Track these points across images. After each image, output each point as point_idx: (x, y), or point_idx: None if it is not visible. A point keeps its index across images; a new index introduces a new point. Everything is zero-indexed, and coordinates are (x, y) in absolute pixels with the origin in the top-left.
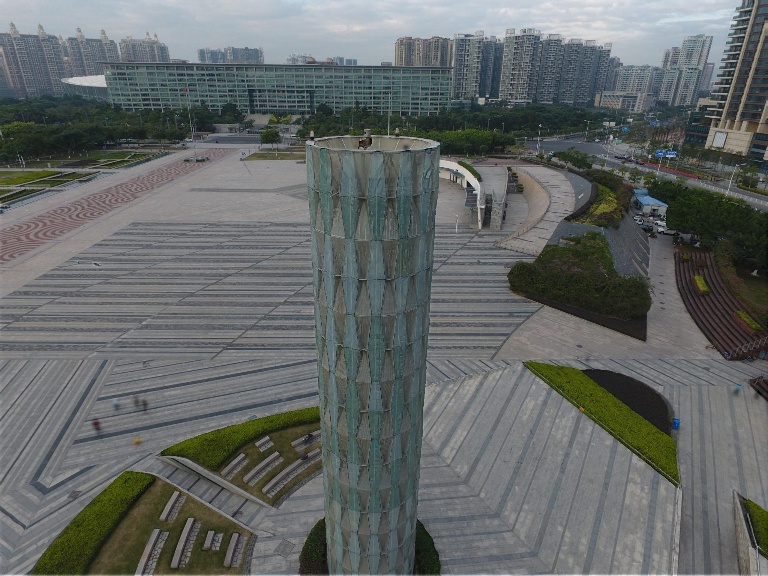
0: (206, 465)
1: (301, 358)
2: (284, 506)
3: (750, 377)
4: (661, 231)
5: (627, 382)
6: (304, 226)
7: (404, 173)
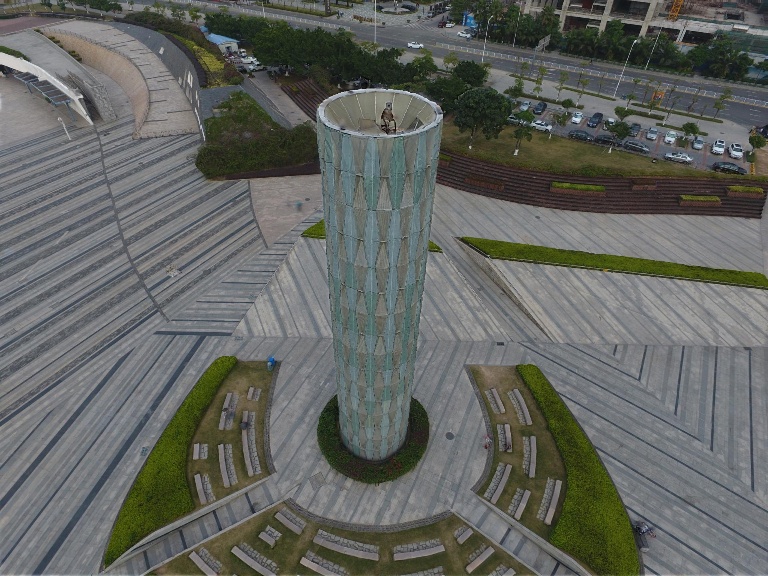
0: (181, 514)
1: (103, 369)
2: (278, 465)
3: None
4: (253, 69)
5: None
6: None
7: None
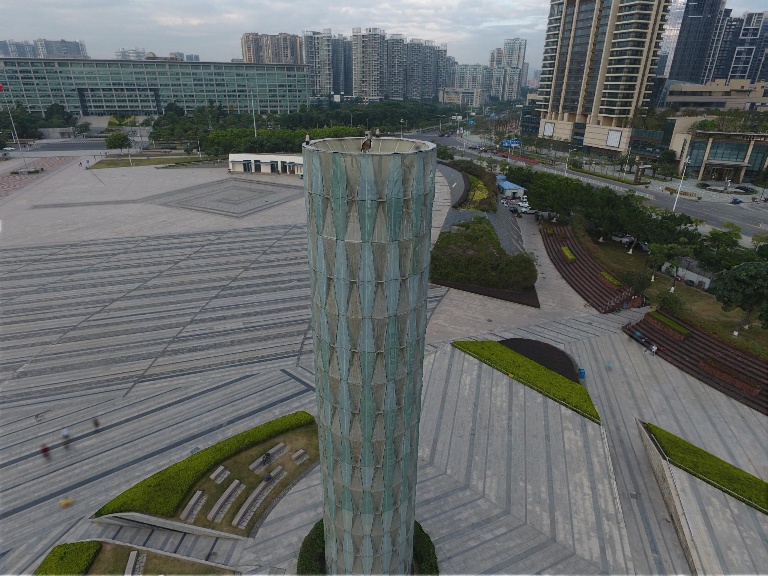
0: (160, 513)
1: (230, 377)
2: (261, 533)
3: (621, 325)
4: (524, 211)
5: (536, 345)
6: (188, 237)
7: (416, 173)
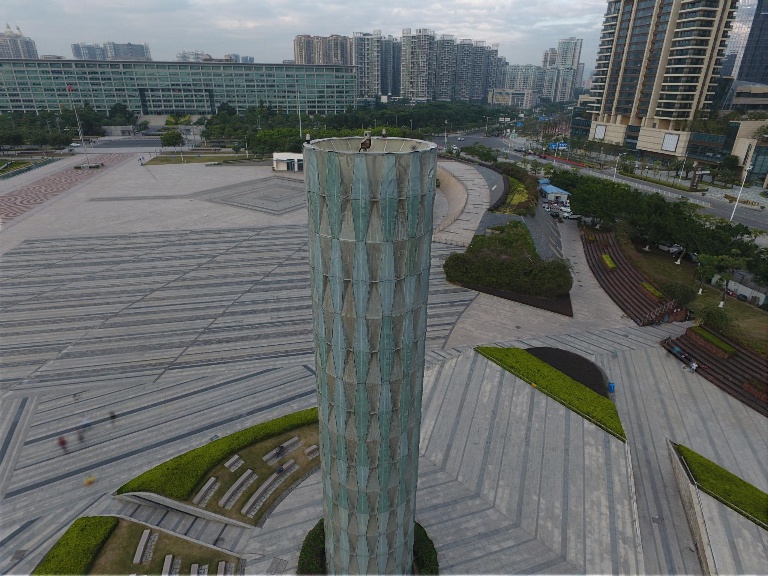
0: (174, 496)
1: (254, 369)
2: (268, 524)
3: (660, 339)
4: (566, 216)
5: (565, 355)
6: (228, 232)
7: (412, 173)
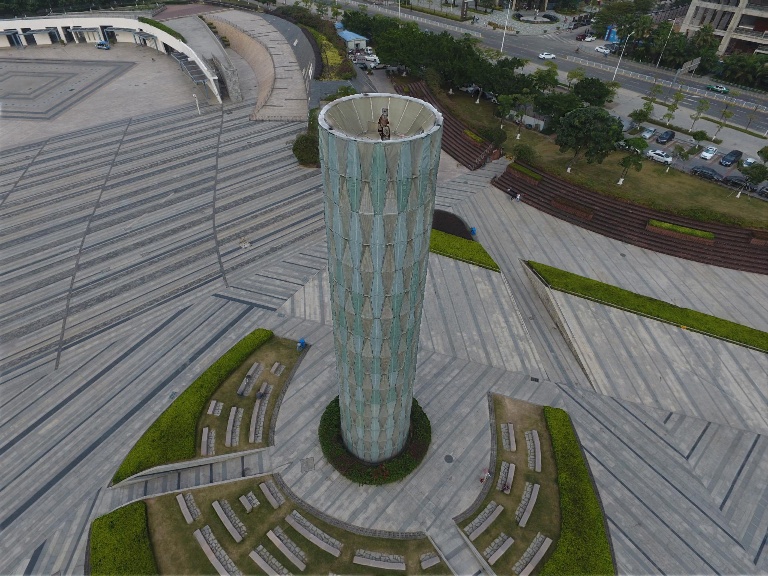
0: (182, 458)
1: (164, 316)
2: (278, 440)
3: (489, 179)
4: (373, 67)
5: None
6: None
7: None
